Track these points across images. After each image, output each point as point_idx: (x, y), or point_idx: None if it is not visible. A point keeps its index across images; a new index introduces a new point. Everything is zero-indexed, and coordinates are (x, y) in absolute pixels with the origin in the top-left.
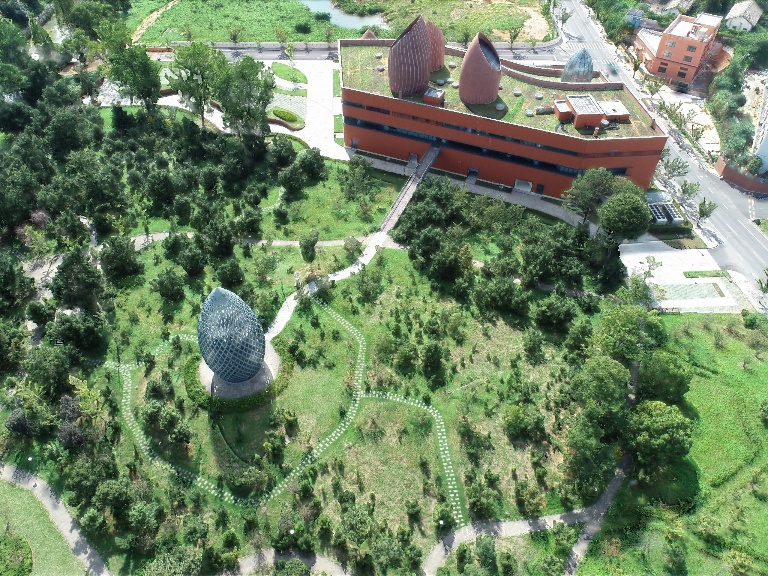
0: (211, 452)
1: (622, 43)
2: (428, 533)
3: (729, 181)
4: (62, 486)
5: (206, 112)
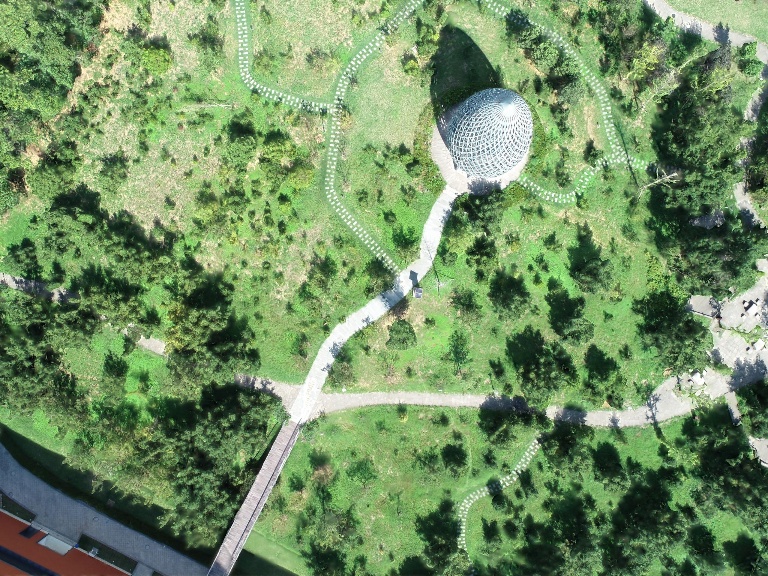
0: (497, 41)
1: None
2: None
3: None
4: (646, 15)
5: None
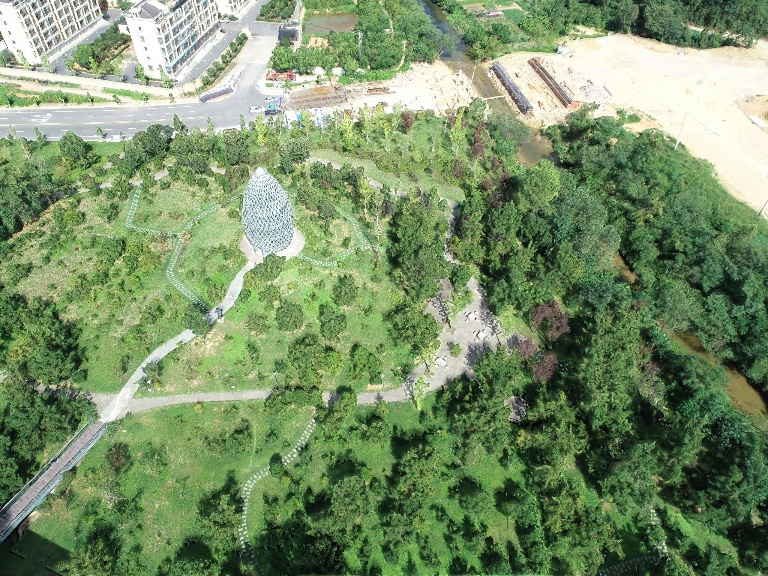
0: None
1: None
2: None
3: None
4: None
5: None
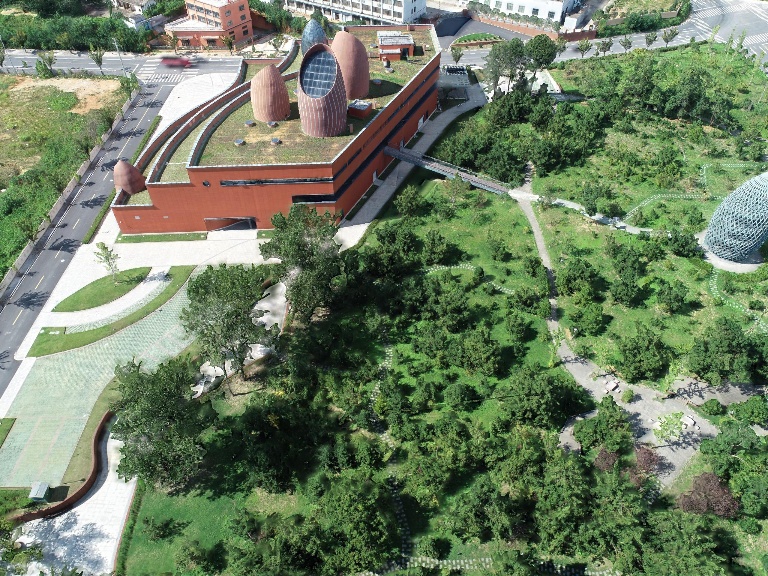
0: None
1: (164, 46)
2: None
3: None
4: None
5: (196, 386)
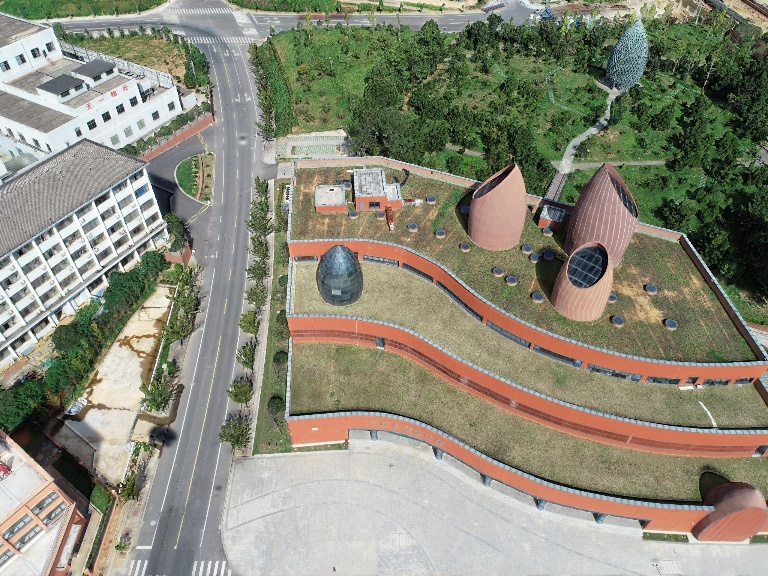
0: None
1: None
2: (502, 55)
3: (189, 246)
4: None
5: None
